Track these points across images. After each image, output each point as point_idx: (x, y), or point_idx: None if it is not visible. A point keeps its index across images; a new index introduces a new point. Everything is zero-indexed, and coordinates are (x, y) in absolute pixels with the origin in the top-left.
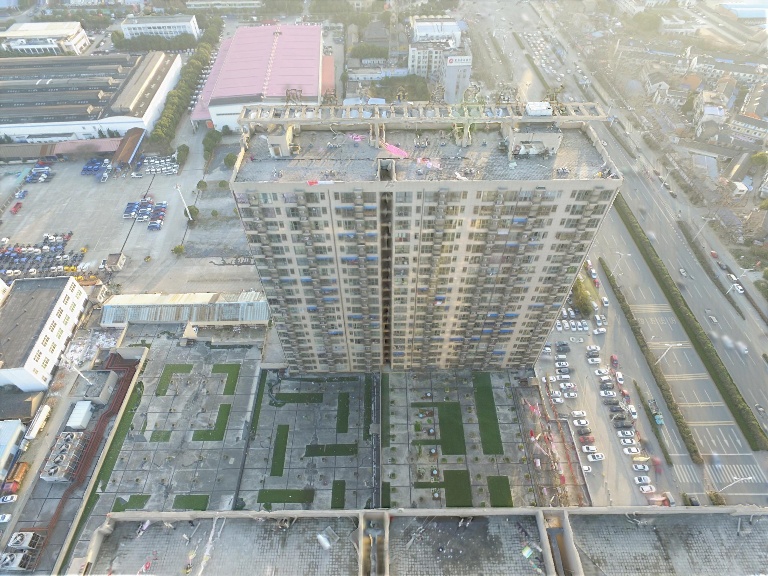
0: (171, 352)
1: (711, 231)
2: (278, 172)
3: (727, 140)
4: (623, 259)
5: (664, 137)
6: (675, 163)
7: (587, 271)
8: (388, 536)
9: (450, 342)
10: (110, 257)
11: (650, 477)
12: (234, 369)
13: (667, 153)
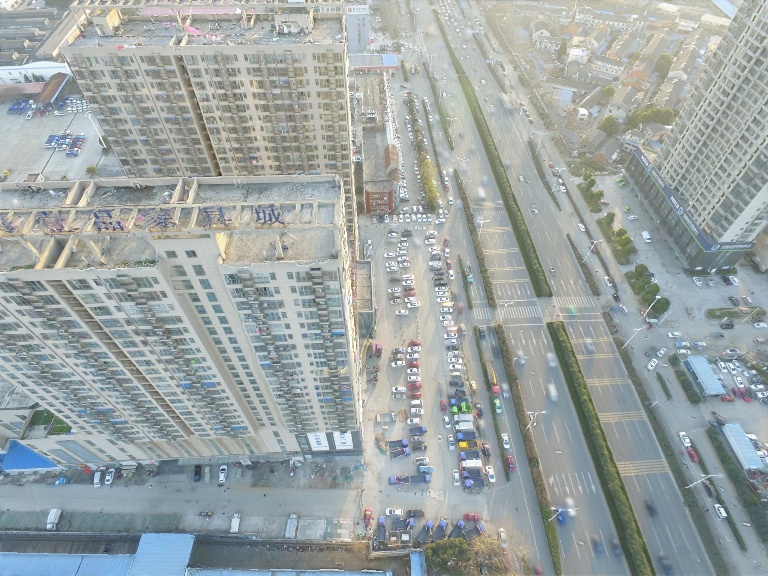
0: None
1: (554, 148)
2: (100, 44)
3: (585, 76)
4: (474, 170)
5: (535, 76)
6: (539, 96)
7: (442, 179)
8: (90, 190)
9: None
10: (29, 177)
11: (452, 316)
12: None
13: (534, 88)
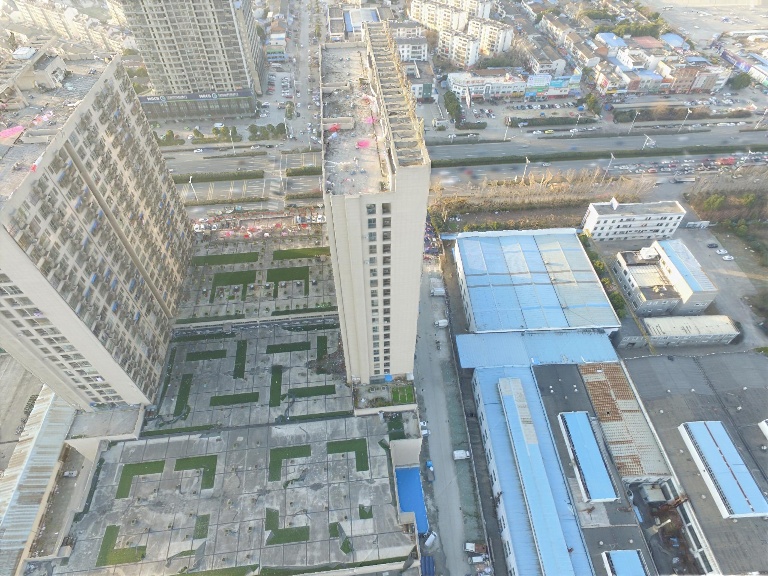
0: (75, 568)
1: None
2: None
3: None
4: None
5: None
6: None
7: None
8: None
9: (168, 253)
10: None
11: None
12: (129, 471)
13: None
